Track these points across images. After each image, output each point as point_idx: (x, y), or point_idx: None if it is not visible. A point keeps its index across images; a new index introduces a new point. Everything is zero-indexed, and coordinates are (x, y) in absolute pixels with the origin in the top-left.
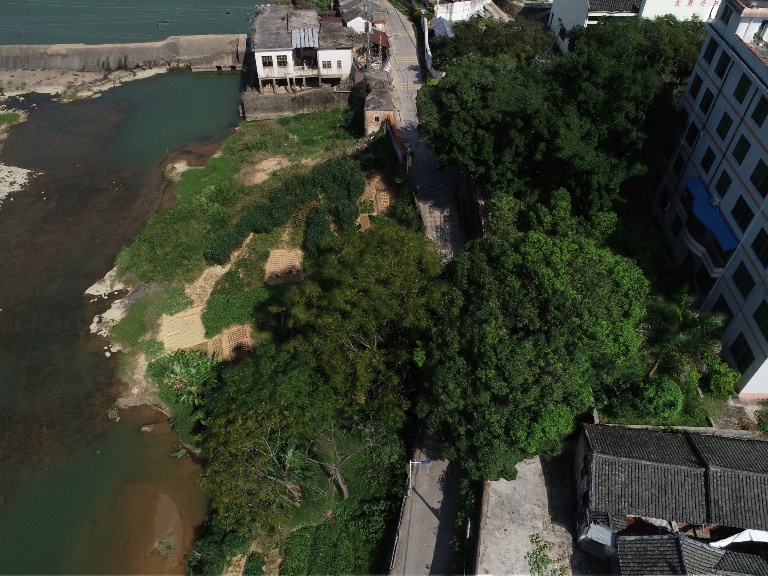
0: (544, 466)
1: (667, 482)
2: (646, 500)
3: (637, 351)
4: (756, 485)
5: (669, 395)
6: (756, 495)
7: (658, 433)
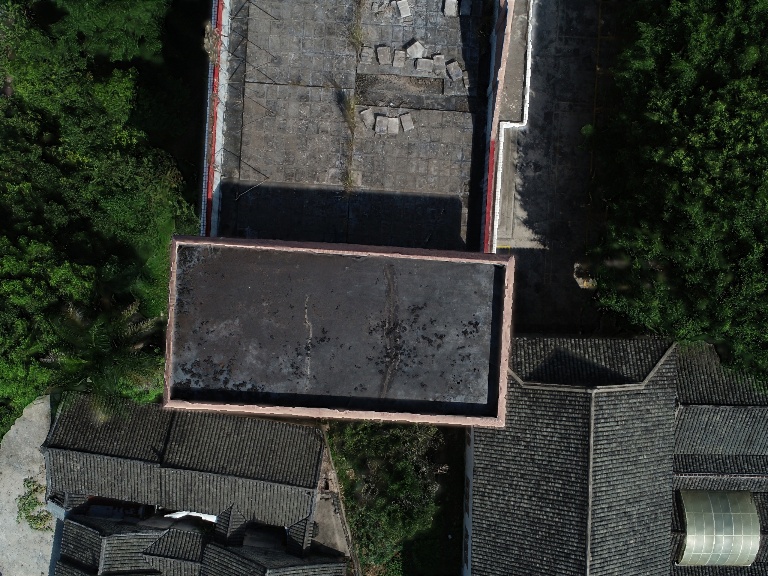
0: (53, 406)
1: (123, 472)
2: (102, 484)
3: (45, 384)
4: (208, 482)
5: (137, 387)
6: (207, 489)
7: (146, 404)
